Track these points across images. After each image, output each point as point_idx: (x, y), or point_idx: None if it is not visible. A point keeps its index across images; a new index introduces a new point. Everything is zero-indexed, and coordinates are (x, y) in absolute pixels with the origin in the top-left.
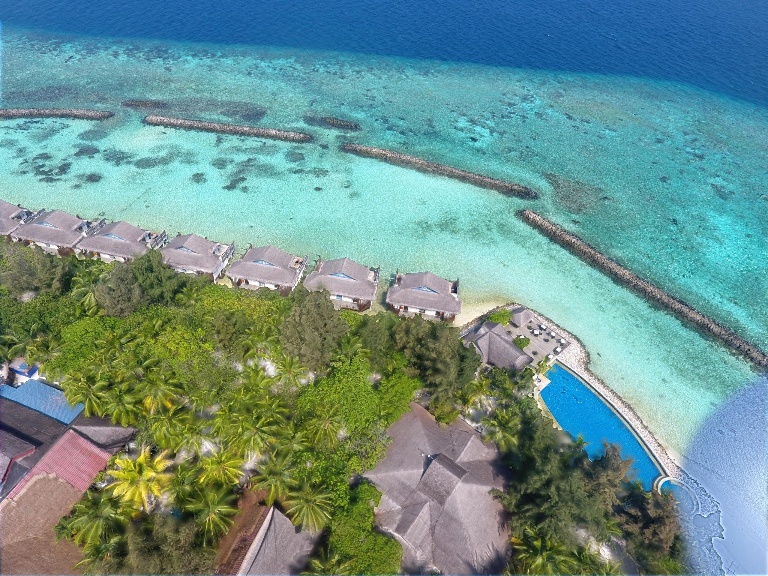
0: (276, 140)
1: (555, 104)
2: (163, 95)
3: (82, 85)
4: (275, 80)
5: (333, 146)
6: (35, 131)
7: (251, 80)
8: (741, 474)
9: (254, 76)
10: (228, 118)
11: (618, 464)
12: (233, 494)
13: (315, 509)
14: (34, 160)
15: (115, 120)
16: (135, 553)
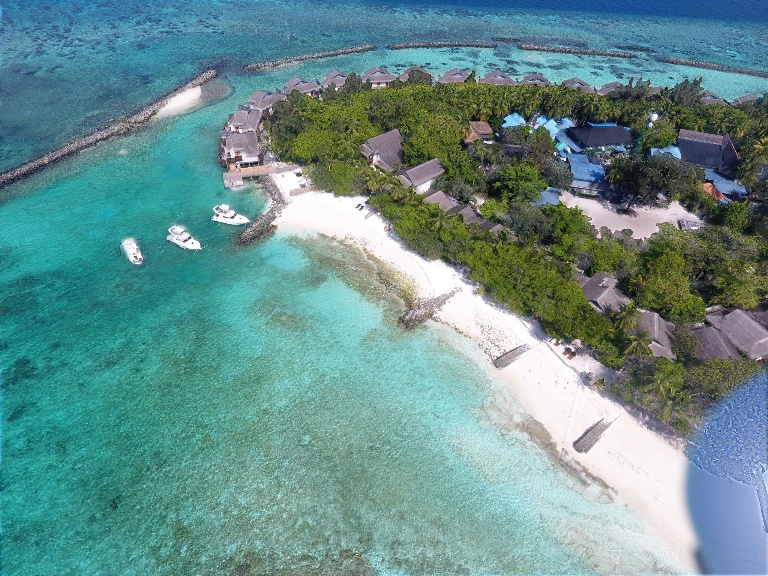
0: (614, 57)
1: (763, 39)
2: (509, 35)
3: (449, 30)
4: (565, 27)
5: (652, 60)
6: (465, 53)
7: (550, 27)
8: None
9: (548, 25)
10: (568, 47)
11: None
12: None
13: None
14: (490, 66)
15: (503, 48)
16: None
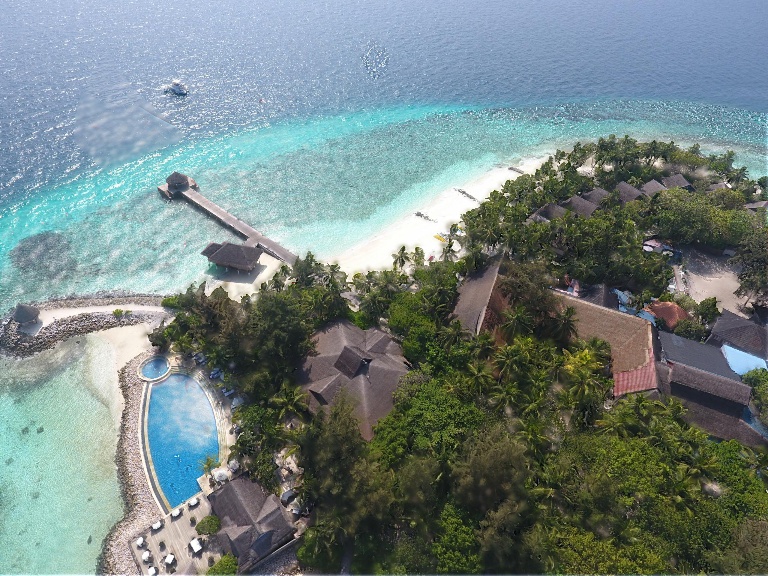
0: None
1: None
2: None
3: None
4: None
5: None
6: None
7: None
8: (69, 392)
9: None
10: None
11: (232, 316)
12: (507, 336)
13: (449, 329)
14: None
15: None
16: (542, 271)
